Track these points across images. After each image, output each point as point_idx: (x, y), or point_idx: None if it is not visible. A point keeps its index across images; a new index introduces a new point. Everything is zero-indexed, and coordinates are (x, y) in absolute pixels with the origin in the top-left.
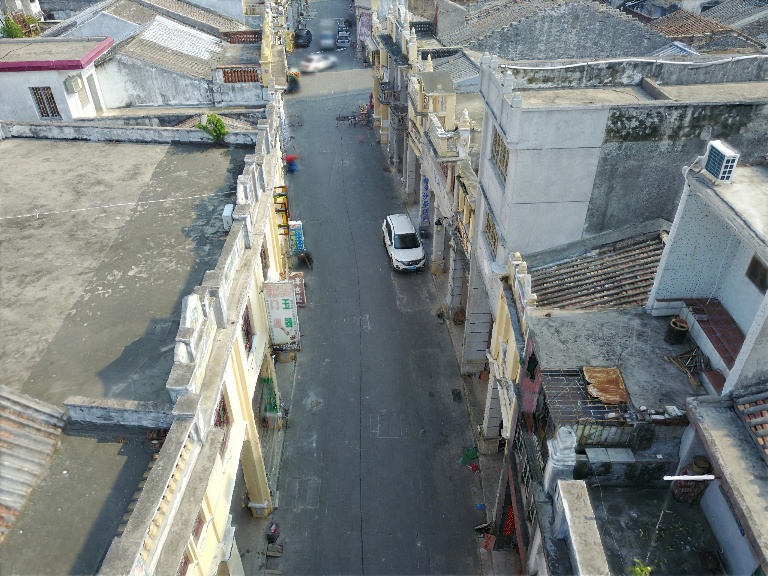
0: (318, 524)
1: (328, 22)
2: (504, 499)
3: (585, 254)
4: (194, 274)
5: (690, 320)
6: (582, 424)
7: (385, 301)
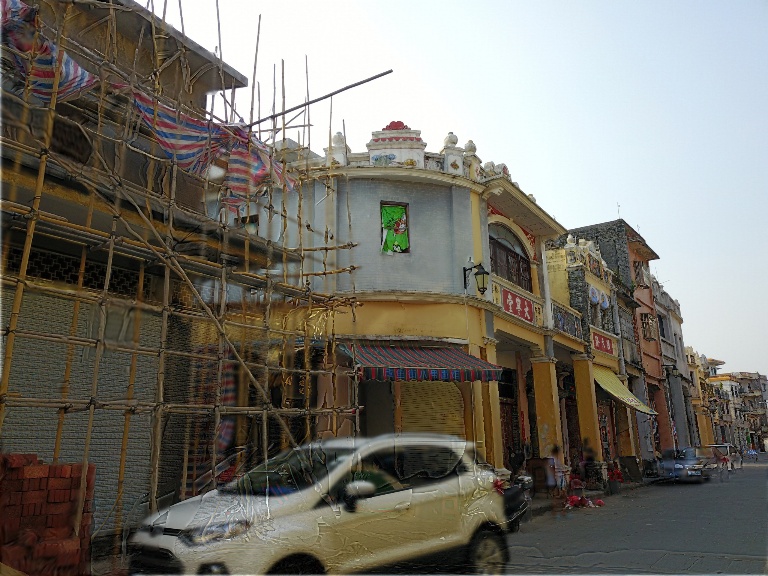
0: None
1: (761, 486)
2: None
3: None
4: None
5: None
6: None
7: None
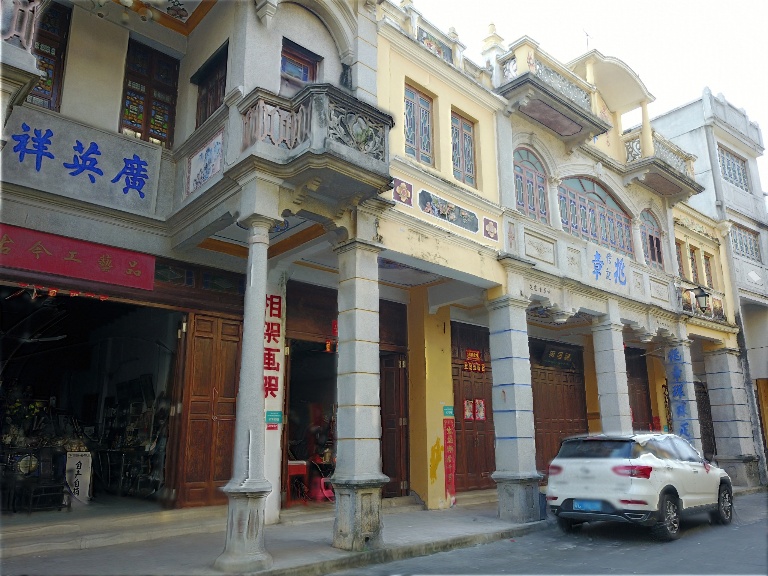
0: None
1: None
2: None
3: None
4: None
5: None
6: None
7: None
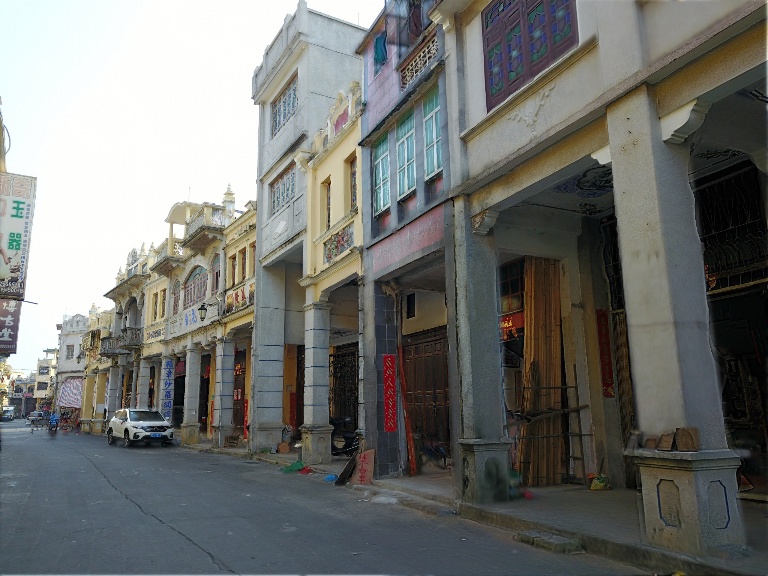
0: (28, 505)
1: None
2: (375, 339)
3: None
4: None
5: None
6: None
7: (121, 453)
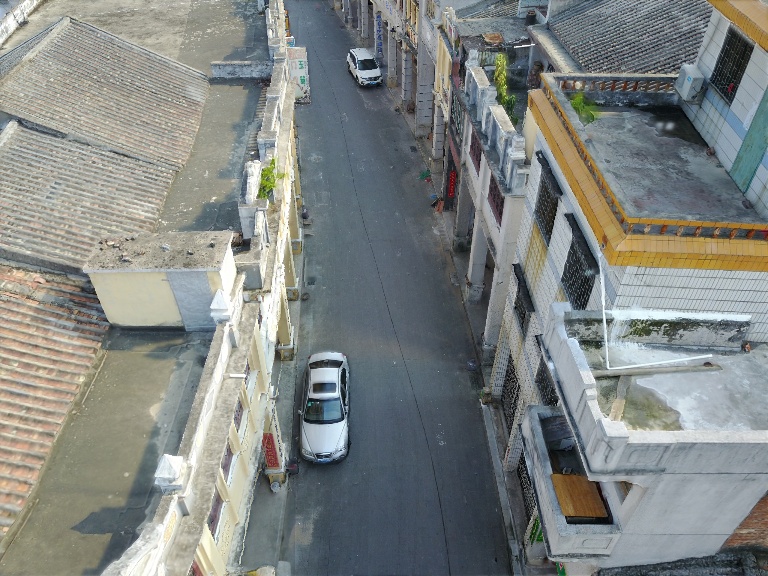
0: (332, 210)
1: None
2: (447, 165)
3: (487, 8)
4: (249, 30)
5: (538, 15)
6: (481, 51)
7: (356, 105)
